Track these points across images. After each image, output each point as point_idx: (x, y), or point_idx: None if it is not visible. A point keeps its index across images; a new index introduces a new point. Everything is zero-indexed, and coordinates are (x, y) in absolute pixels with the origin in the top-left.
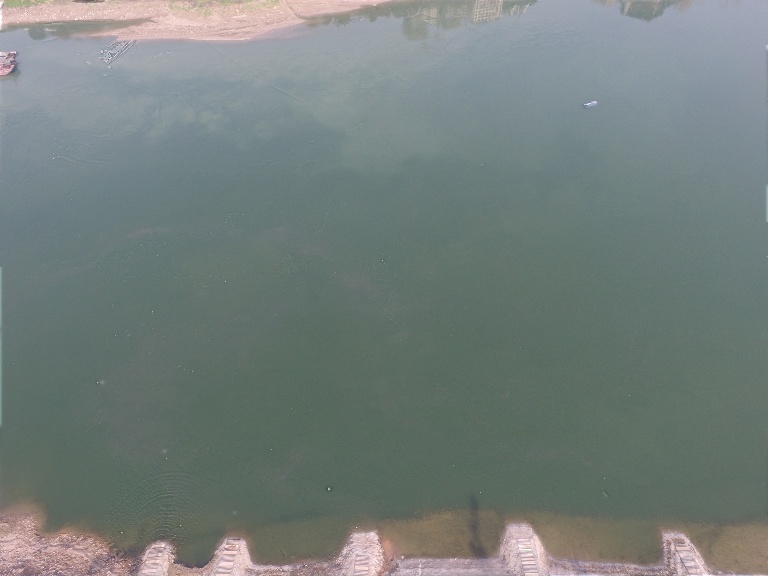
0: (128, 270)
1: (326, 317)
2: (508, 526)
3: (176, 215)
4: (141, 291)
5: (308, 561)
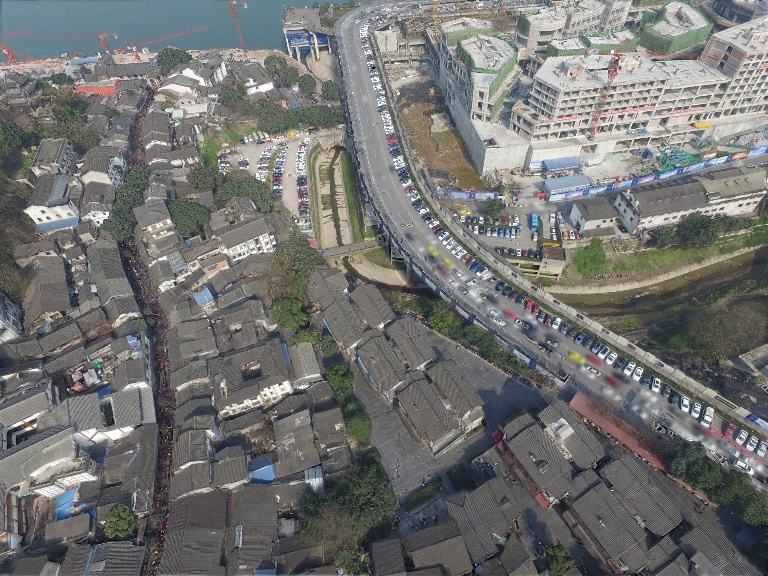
0: (5, 18)
1: (92, 22)
2: None
3: (34, 5)
4: (10, 22)
5: None
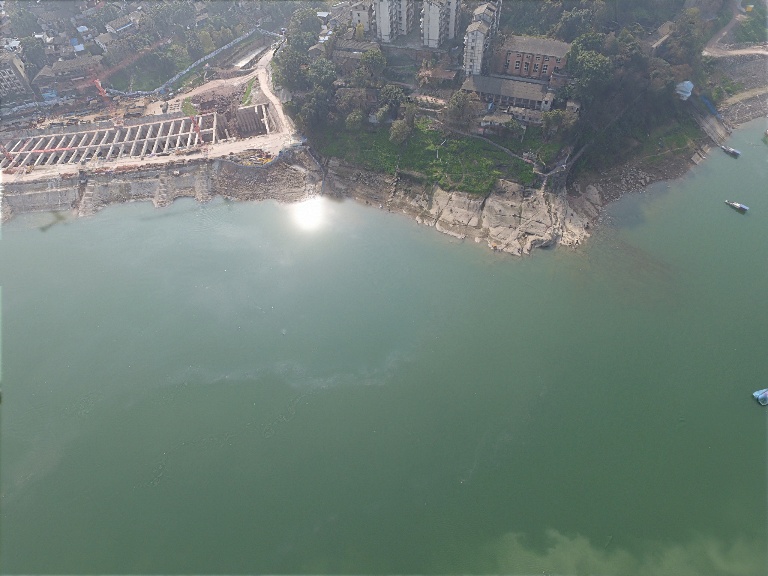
0: (285, 380)
1: (65, 342)
2: (0, 225)
3: (249, 492)
4: (261, 353)
5: (121, 204)
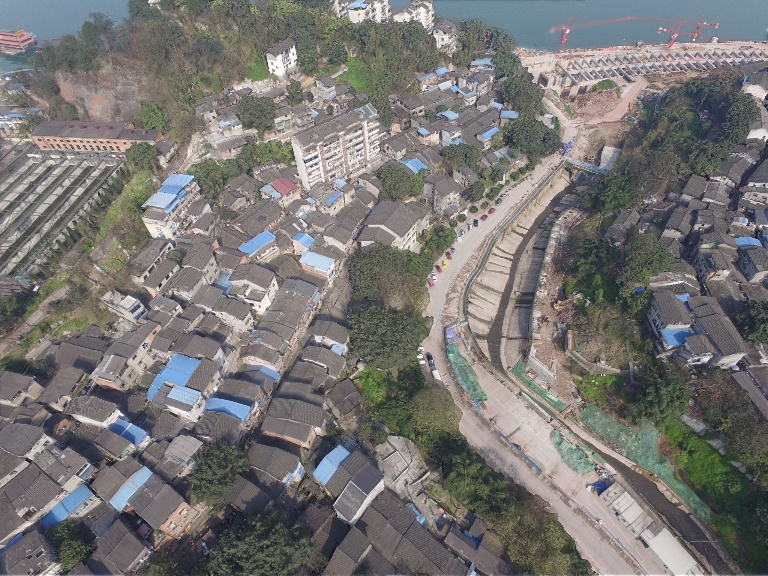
0: (460, 8)
1: (564, 13)
2: None
3: None
4: (473, 11)
5: None
